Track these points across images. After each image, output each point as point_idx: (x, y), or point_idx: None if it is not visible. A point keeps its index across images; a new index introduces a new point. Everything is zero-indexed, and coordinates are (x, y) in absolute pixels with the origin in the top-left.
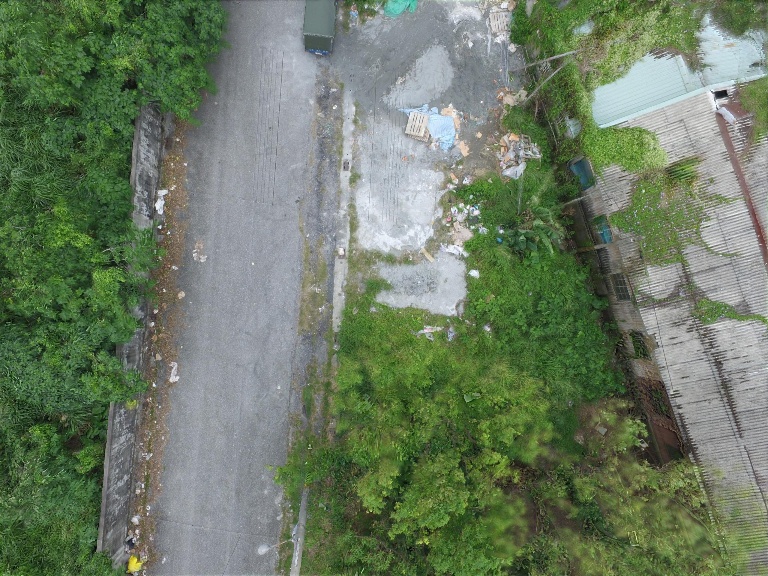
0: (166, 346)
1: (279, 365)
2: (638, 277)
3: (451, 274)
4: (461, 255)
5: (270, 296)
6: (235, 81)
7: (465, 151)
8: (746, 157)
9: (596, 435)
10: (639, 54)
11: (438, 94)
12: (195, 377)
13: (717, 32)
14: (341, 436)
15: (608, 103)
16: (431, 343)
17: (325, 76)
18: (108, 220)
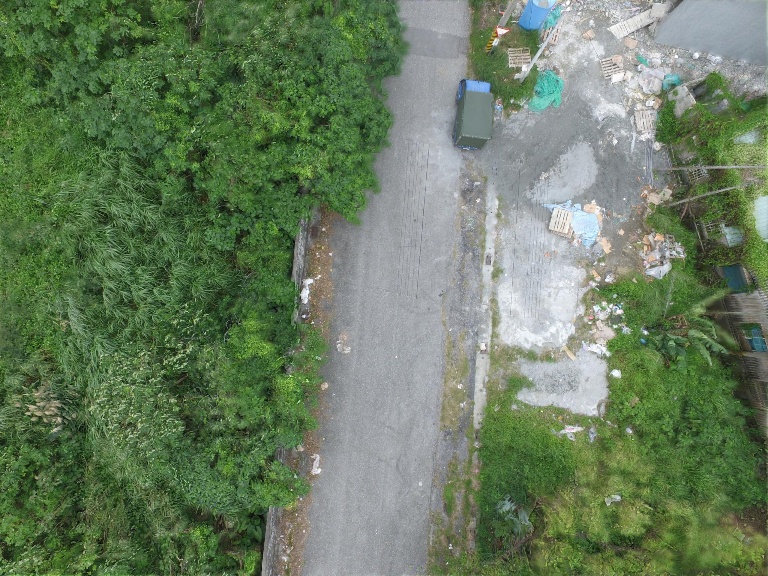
0: (308, 437)
1: (421, 461)
2: None
3: (592, 373)
4: (603, 354)
5: (413, 391)
6: (381, 172)
7: (607, 248)
8: None
9: (733, 541)
10: None
11: (582, 190)
12: (337, 470)
13: None
14: (482, 536)
15: None
16: (573, 444)
17: (469, 169)
18: (281, 326)
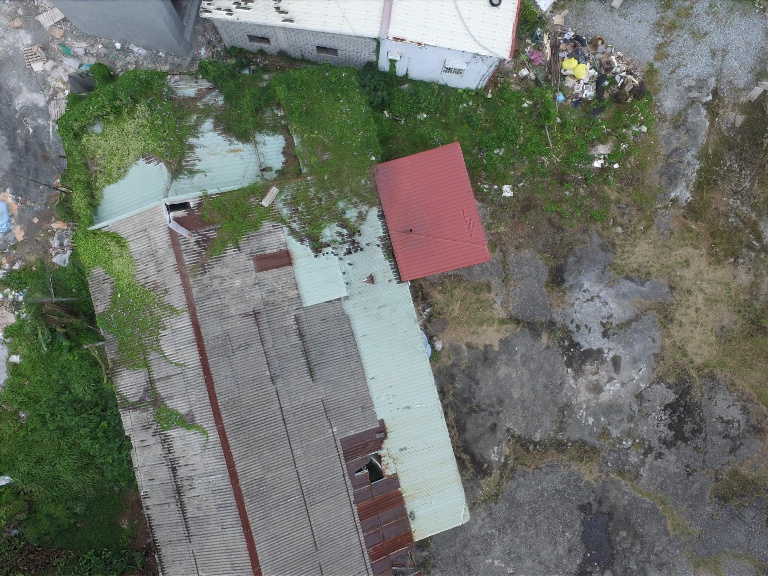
0: None
1: None
2: (117, 378)
3: None
4: (3, 340)
5: None
6: None
7: (20, 236)
8: (201, 269)
9: (142, 519)
10: (131, 158)
11: None
12: None
13: (223, 137)
14: None
15: (113, 203)
16: None
17: None
18: None
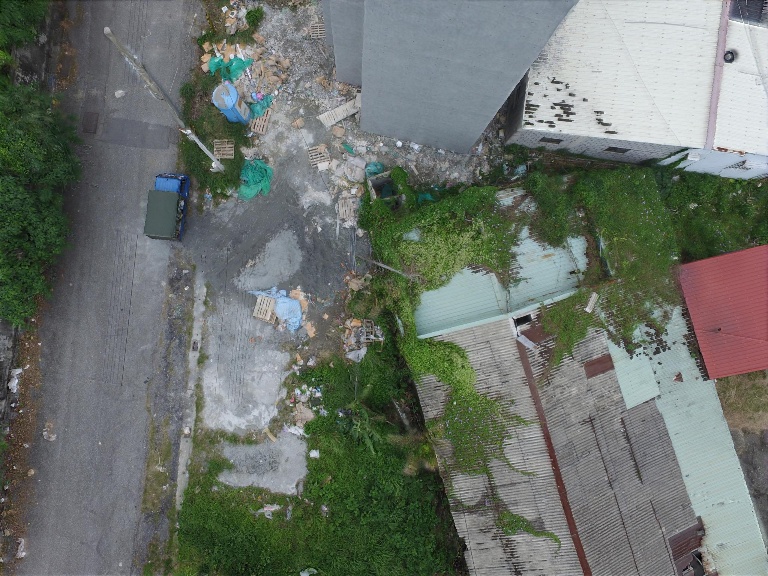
0: (14, 523)
1: (121, 543)
2: None
3: (293, 453)
4: (302, 435)
5: (115, 475)
6: (90, 263)
7: (311, 332)
8: (546, 380)
9: None
10: (458, 268)
11: (286, 277)
12: (40, 554)
13: (537, 243)
14: None
15: (432, 308)
16: (269, 522)
17: (178, 258)
18: None
